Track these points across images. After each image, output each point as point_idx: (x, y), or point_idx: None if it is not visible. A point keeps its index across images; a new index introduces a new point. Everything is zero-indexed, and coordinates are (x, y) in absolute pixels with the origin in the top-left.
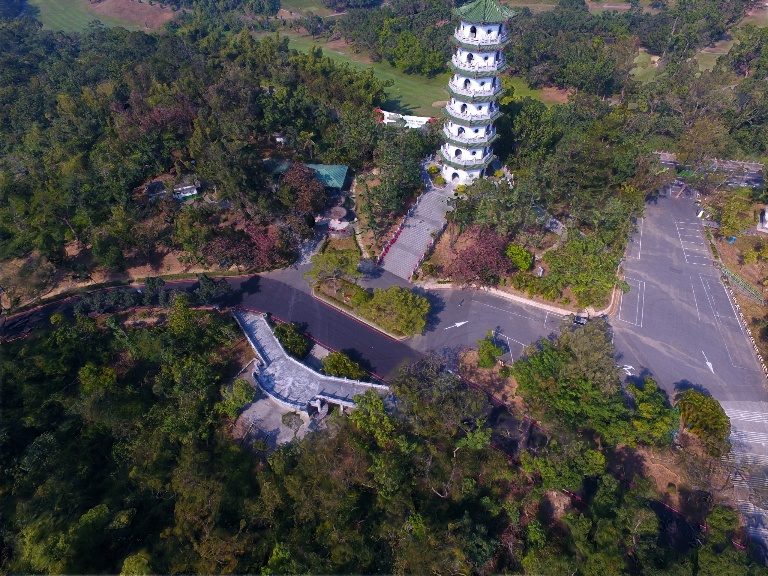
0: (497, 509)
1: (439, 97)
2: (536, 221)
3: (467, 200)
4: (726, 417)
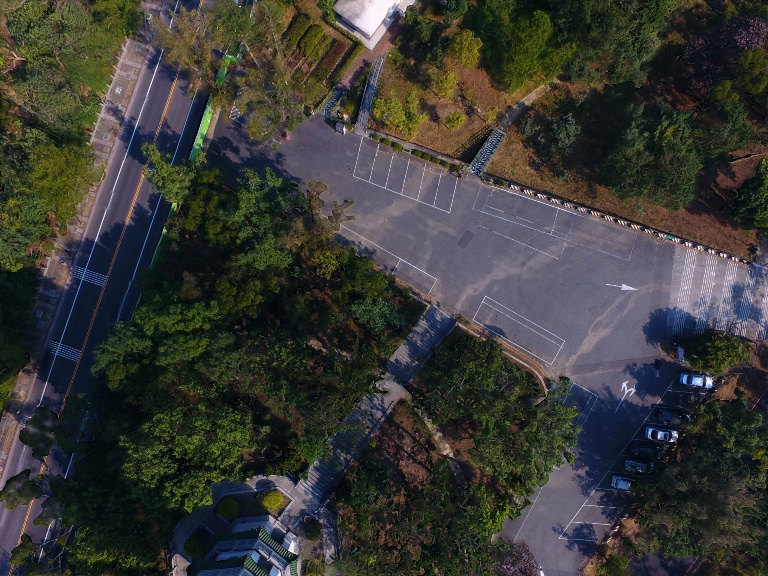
0: None
1: None
2: (373, 436)
3: None
4: (733, 342)
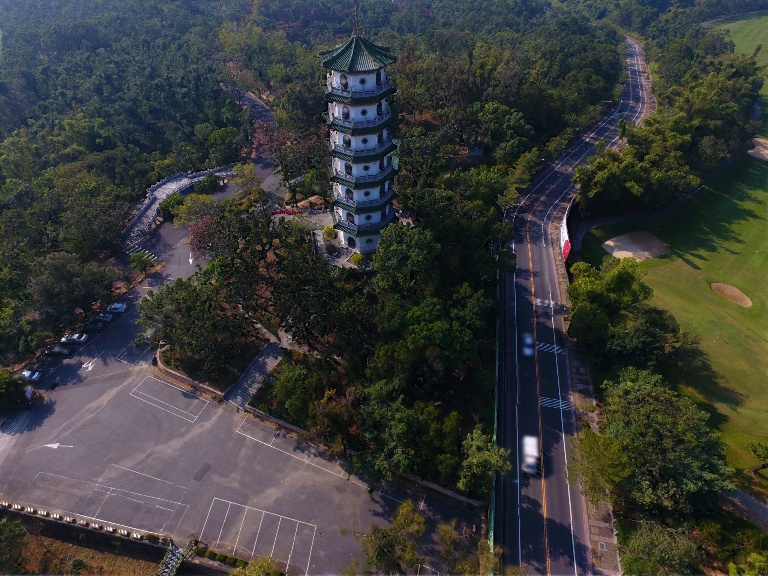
0: None
1: (760, 292)
2: None
3: None
4: None
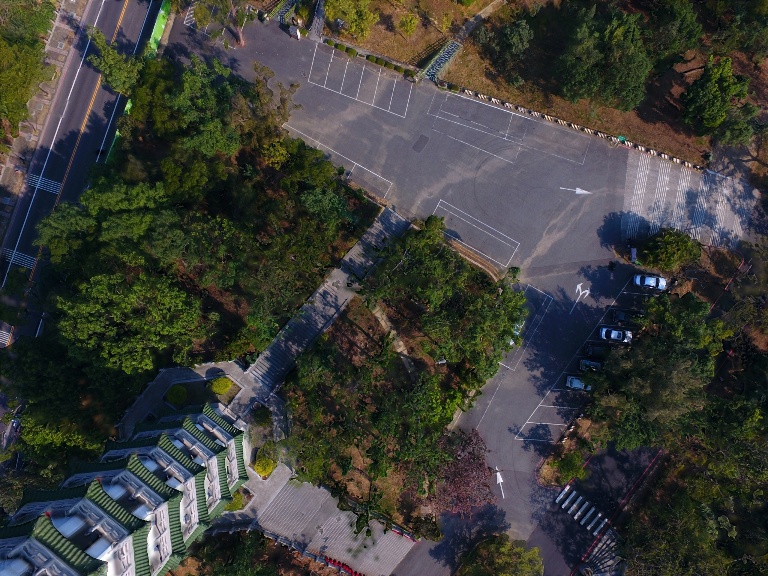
0: None
1: None
2: (325, 331)
3: None
4: (683, 237)
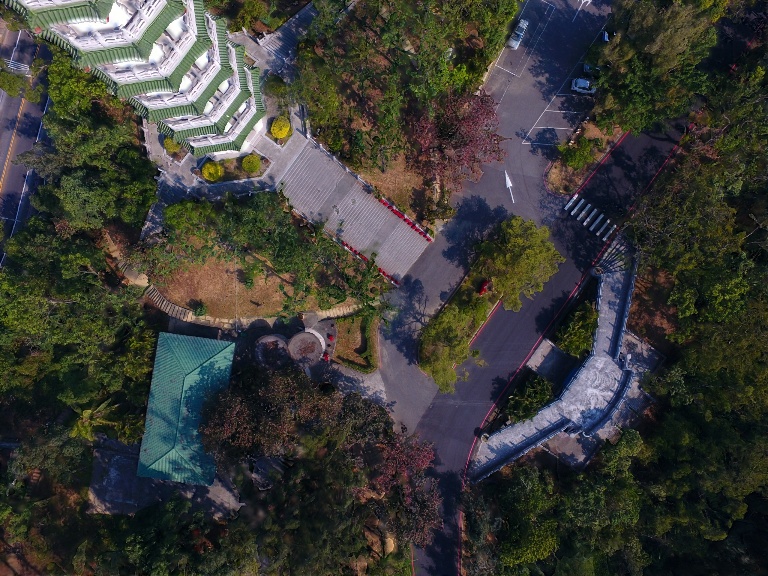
0: (751, 183)
1: None
2: None
3: (331, 126)
4: None
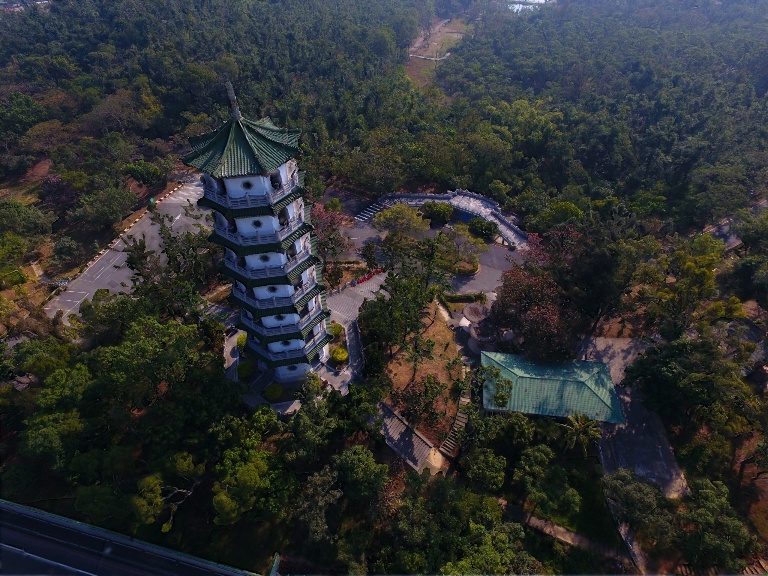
0: None
1: None
2: None
3: None
4: None
